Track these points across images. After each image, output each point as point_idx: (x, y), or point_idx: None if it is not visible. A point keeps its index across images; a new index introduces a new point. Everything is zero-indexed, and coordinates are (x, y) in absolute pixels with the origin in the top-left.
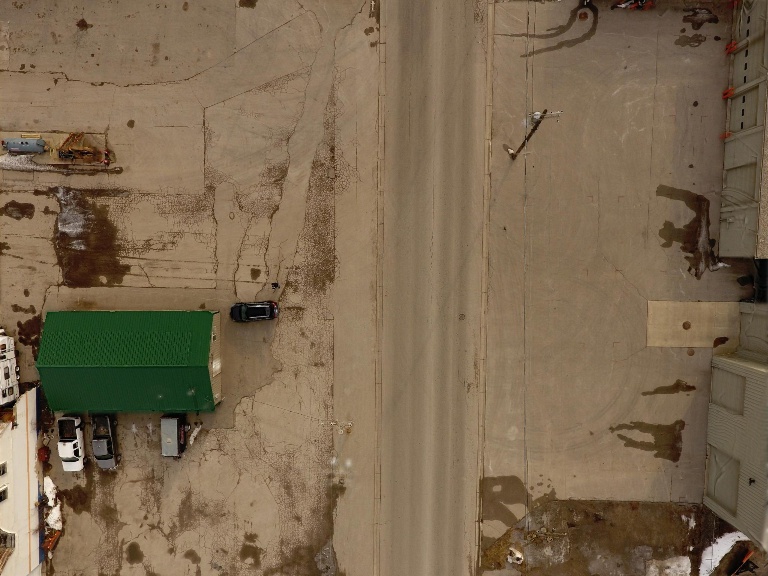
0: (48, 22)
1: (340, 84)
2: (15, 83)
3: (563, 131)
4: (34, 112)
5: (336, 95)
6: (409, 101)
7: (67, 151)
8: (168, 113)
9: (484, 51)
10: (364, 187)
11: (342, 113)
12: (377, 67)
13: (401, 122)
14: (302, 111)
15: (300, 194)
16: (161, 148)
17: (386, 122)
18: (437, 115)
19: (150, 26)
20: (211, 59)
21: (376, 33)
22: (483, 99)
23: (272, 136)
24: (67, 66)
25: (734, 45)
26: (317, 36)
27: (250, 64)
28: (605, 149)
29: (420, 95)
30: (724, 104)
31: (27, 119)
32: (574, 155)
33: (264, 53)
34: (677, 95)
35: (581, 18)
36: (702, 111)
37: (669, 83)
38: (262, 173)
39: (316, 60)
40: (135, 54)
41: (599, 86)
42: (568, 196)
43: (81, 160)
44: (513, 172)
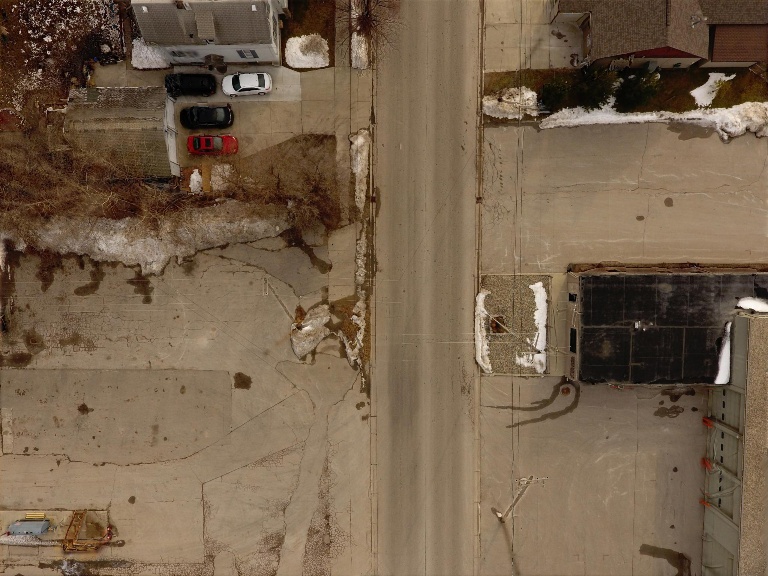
0: (50, 407)
1: (333, 457)
2: (19, 465)
3: (549, 496)
4: (38, 491)
5: (330, 467)
6: (400, 470)
7: (71, 545)
8: (168, 489)
9: (471, 421)
10: (358, 550)
11: (336, 483)
12: (369, 439)
13: (393, 489)
14: (297, 483)
15: (297, 560)
16: (161, 521)
17: (378, 489)
18: (427, 482)
19: (149, 409)
20: (208, 438)
21: (367, 407)
22: (471, 465)
23: (269, 507)
24: (69, 448)
25: (709, 463)
26: (310, 413)
27: (246, 441)
28: (589, 511)
29: (411, 464)
30: (701, 493)
31: (31, 498)
32: (560, 517)
33: (259, 431)
34: (657, 462)
35: (564, 392)
36: (681, 479)
37: (649, 451)
38: (260, 541)
39: (310, 435)
40: (135, 436)
41: (582, 454)
42: (555, 555)
43: (84, 535)
44: (502, 533)
